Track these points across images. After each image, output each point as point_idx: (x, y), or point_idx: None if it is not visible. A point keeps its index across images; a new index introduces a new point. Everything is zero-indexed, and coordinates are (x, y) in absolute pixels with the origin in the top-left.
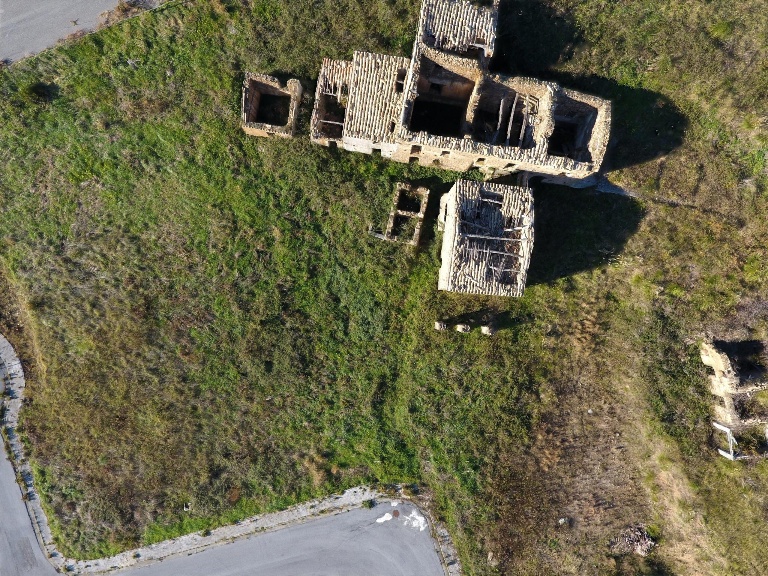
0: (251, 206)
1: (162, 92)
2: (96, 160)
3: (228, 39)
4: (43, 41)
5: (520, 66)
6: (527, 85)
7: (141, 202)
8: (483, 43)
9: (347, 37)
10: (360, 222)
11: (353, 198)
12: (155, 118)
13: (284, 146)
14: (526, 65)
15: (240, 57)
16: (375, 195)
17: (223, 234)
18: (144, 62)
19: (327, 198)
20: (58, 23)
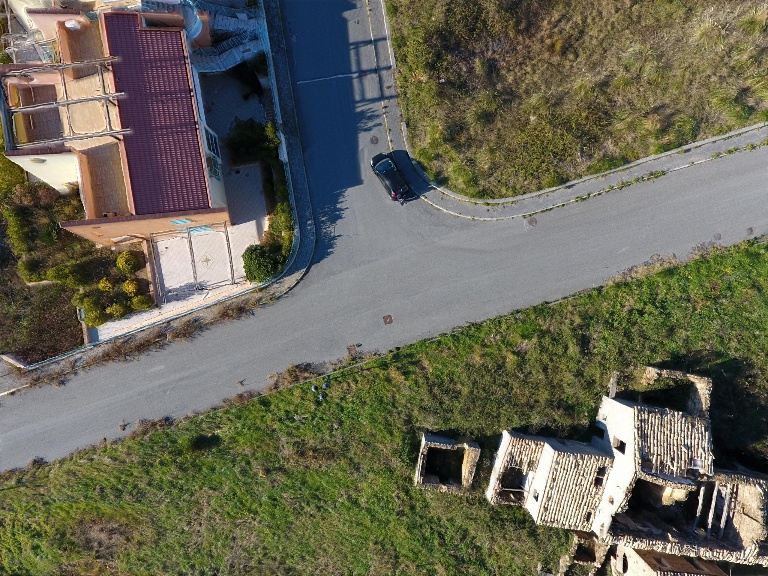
0: (415, 545)
1: (328, 442)
2: (254, 501)
3: (401, 396)
4: (207, 400)
5: (715, 440)
6: (735, 483)
7: (299, 538)
8: (701, 465)
9: (530, 403)
10: (529, 560)
11: (523, 540)
12: (319, 466)
13: (457, 499)
14: (722, 441)
15: (412, 413)
16: (549, 542)
17: (384, 569)
18: (312, 418)
19: (495, 539)
20: (223, 382)
